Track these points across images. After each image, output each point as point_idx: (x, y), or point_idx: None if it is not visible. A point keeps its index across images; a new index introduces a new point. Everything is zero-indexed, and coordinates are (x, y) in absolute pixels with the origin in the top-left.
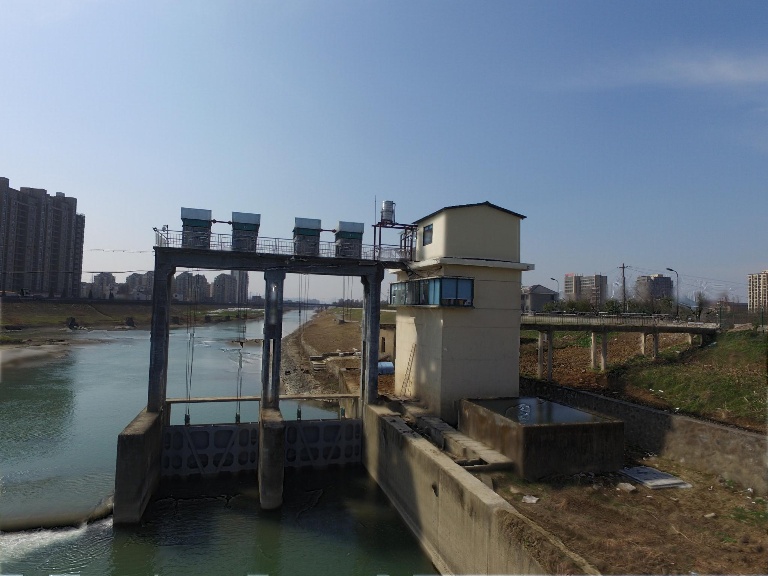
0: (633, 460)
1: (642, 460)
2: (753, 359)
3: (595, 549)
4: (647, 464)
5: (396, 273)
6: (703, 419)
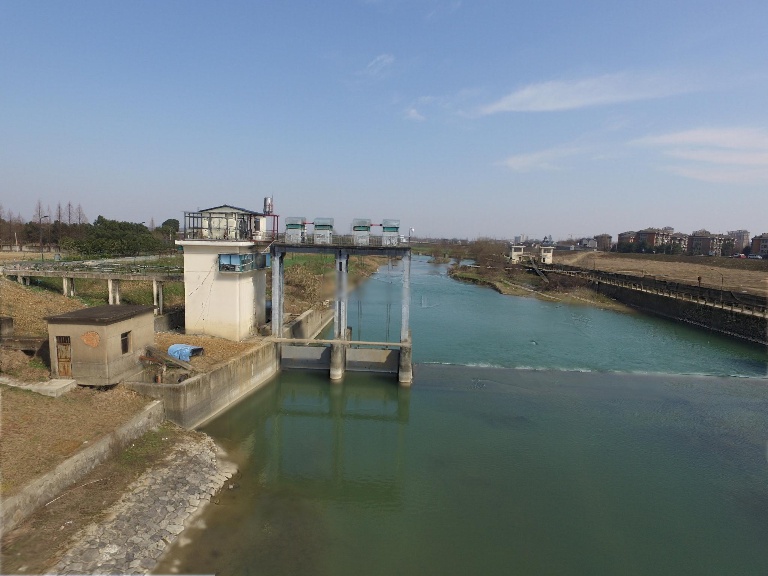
0: None
1: None
2: (78, 285)
3: None
4: None
5: (245, 246)
6: None
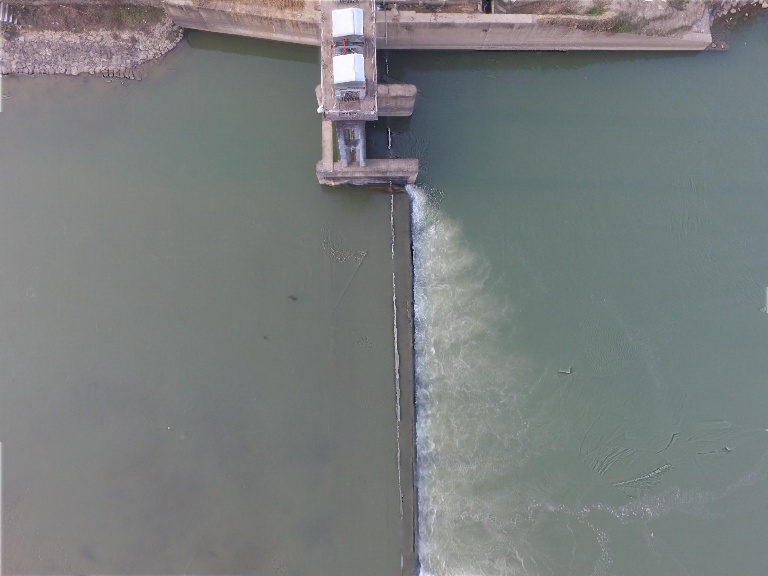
0: None
1: None
2: None
3: (548, 0)
4: None
5: None
6: None
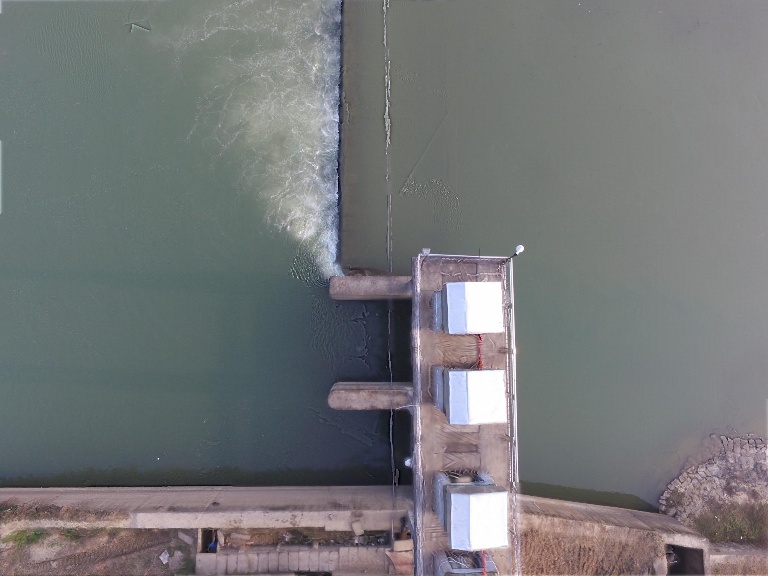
0: None
1: None
2: None
3: (107, 557)
4: None
5: None
6: None
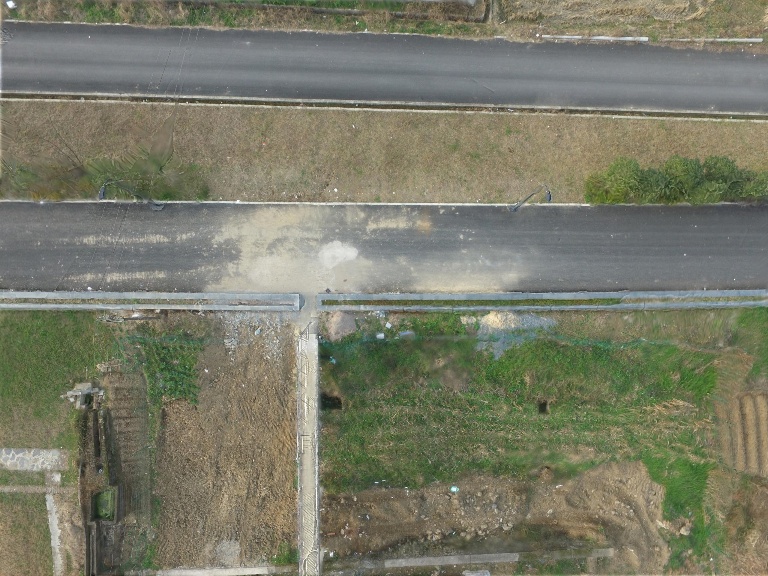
0: (454, 574)
1: (456, 569)
2: (385, 379)
3: None
4: (460, 570)
5: None
6: (428, 489)
